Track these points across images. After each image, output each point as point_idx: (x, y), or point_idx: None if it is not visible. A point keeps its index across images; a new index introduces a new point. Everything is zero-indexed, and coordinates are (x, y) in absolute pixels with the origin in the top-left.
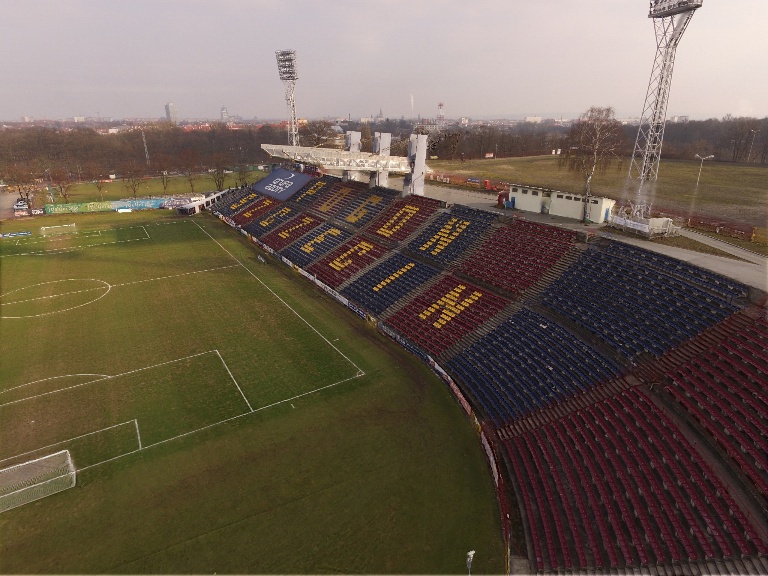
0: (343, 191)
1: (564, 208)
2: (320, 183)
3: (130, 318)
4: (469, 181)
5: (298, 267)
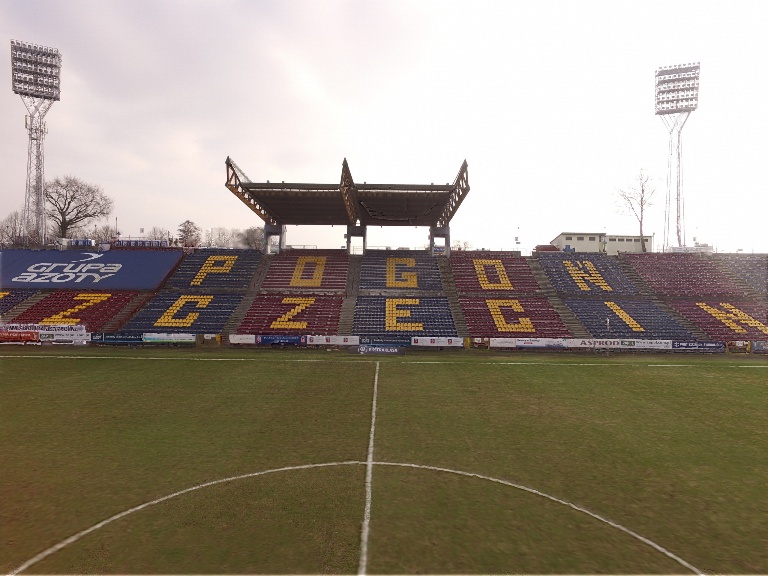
0: (308, 260)
1: (618, 249)
2: (220, 257)
3: (762, 450)
4: (436, 250)
5: (486, 339)
